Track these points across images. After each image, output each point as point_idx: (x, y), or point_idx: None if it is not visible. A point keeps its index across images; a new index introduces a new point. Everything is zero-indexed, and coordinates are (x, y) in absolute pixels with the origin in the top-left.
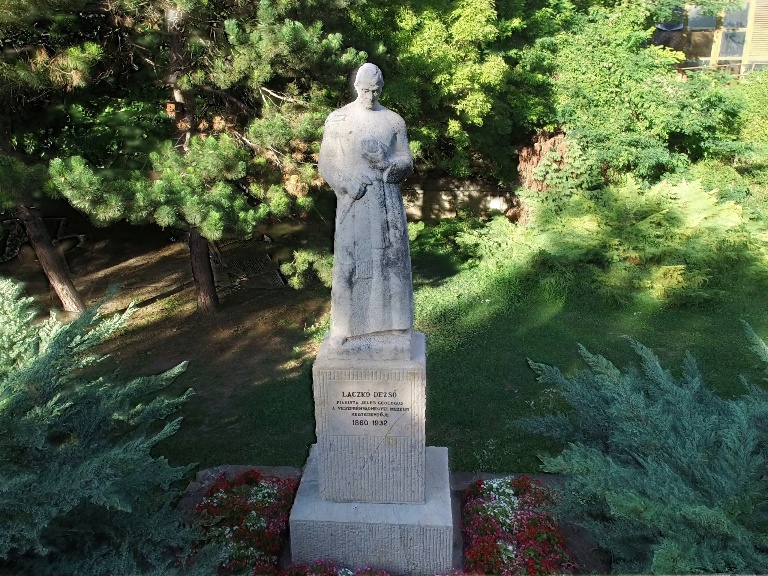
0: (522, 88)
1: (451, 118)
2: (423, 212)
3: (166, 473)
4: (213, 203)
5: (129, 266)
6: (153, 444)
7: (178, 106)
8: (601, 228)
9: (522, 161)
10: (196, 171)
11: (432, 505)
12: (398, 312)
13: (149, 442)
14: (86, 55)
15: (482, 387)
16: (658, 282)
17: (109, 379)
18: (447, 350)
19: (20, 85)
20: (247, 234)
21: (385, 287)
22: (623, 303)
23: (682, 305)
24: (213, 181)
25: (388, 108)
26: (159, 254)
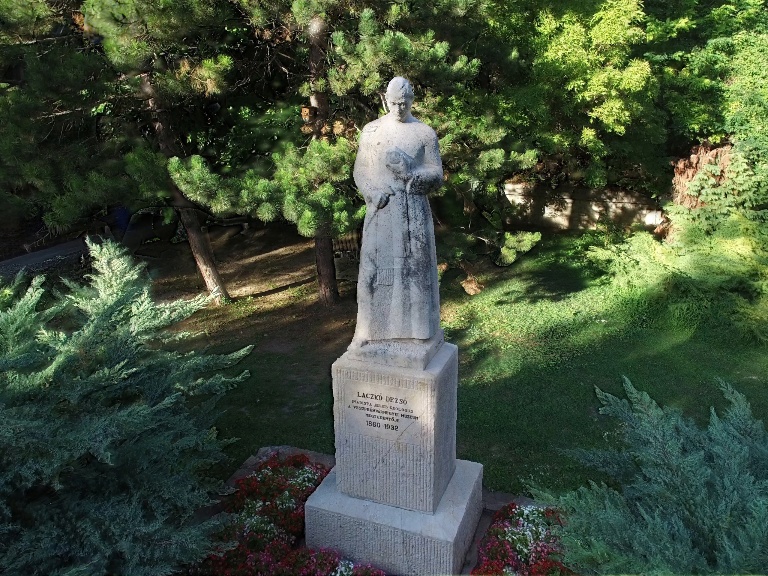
0: (686, 94)
1: (585, 126)
2: (570, 222)
3: (182, 440)
4: (315, 202)
5: (277, 254)
6: (152, 412)
7: (311, 110)
8: (756, 253)
9: (677, 174)
10: (306, 172)
11: (440, 517)
12: (416, 321)
13: (148, 409)
14: (218, 66)
15: (564, 410)
16: None
17: (199, 353)
18: (541, 367)
19: (169, 92)
20: (340, 233)
21: (405, 295)
22: (763, 340)
23: None
24: None
25: (517, 115)
26: (306, 245)
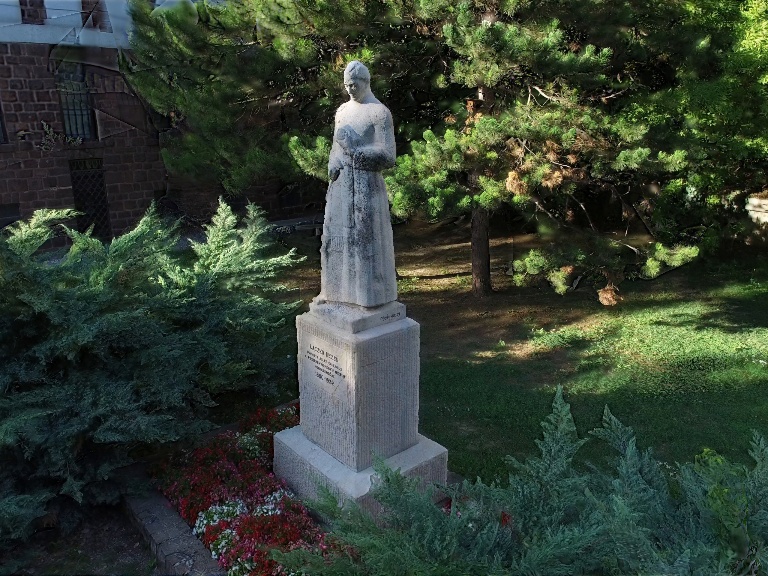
0: None
1: None
2: None
3: None
4: None
5: None
6: (128, 317)
7: (476, 103)
8: None
9: None
10: (427, 159)
11: (362, 476)
12: (358, 288)
13: (125, 315)
14: (362, 59)
15: None
16: None
17: None
18: (639, 392)
19: None
20: (433, 218)
21: (351, 263)
22: None
23: None
24: (468, 172)
25: (701, 112)
26: (505, 241)
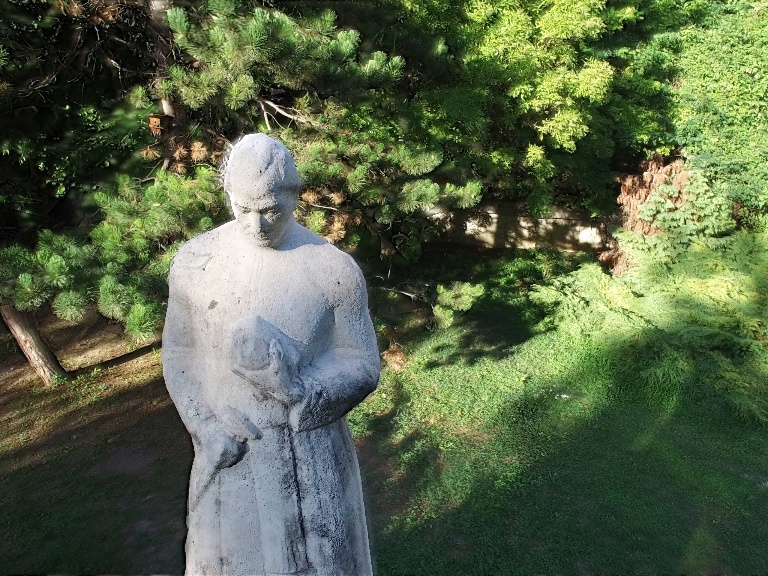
0: (631, 98)
1: (531, 142)
2: (496, 240)
3: None
4: (158, 278)
5: None
6: None
7: (164, 121)
8: (731, 297)
9: (624, 192)
10: (144, 226)
11: None
12: None
13: None
14: None
15: (542, 575)
16: None
17: None
18: (498, 487)
19: None
20: None
21: None
22: (763, 421)
23: None
24: None
25: (446, 128)
26: None
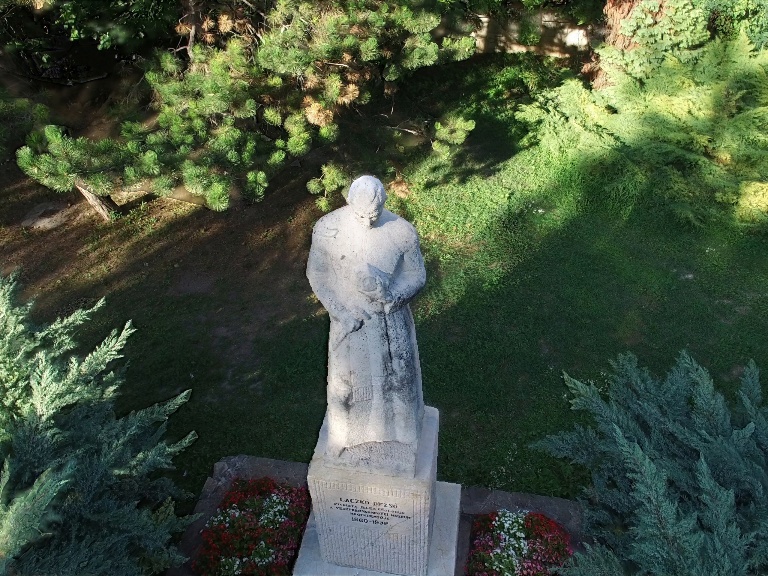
0: None
1: None
2: (486, 45)
3: None
4: (219, 153)
5: None
6: None
7: None
8: (691, 114)
9: (610, 4)
10: (198, 107)
11: None
12: (402, 429)
13: None
14: None
15: (516, 350)
16: (745, 199)
17: (120, 373)
18: (486, 289)
19: None
20: (258, 196)
21: (387, 408)
22: (697, 226)
23: (767, 233)
24: None
25: None
26: None
